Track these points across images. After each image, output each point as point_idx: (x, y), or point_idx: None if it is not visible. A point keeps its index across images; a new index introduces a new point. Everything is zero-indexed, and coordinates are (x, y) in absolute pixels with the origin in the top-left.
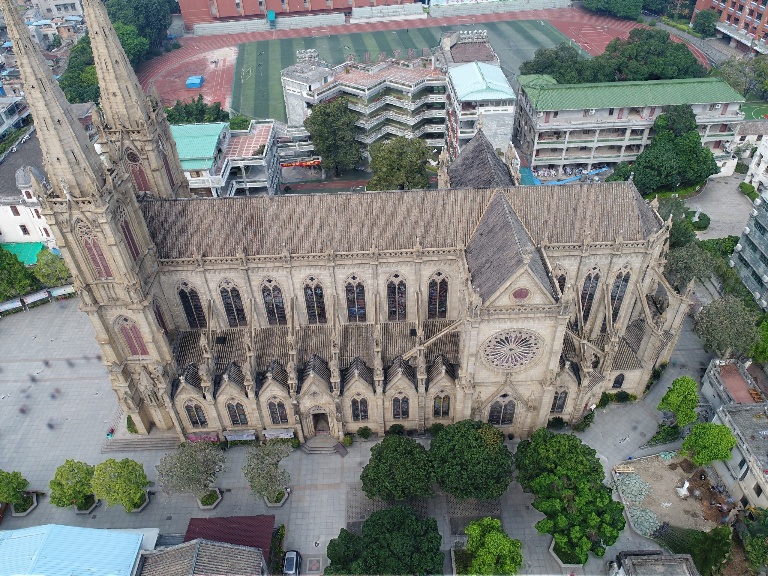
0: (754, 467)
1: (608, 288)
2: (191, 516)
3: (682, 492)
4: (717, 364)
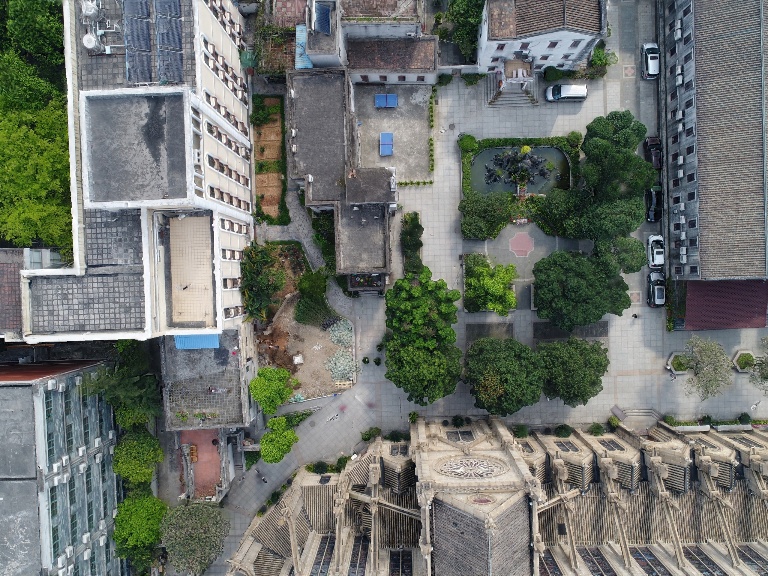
0: (243, 359)
1: (337, 567)
2: (758, 344)
3: (299, 359)
4: (214, 498)
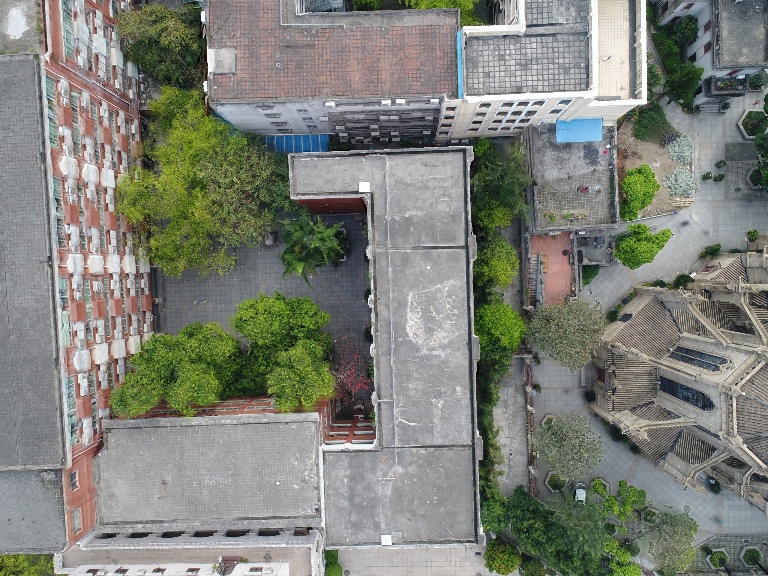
0: None
1: (767, 339)
2: None
3: None
4: None
